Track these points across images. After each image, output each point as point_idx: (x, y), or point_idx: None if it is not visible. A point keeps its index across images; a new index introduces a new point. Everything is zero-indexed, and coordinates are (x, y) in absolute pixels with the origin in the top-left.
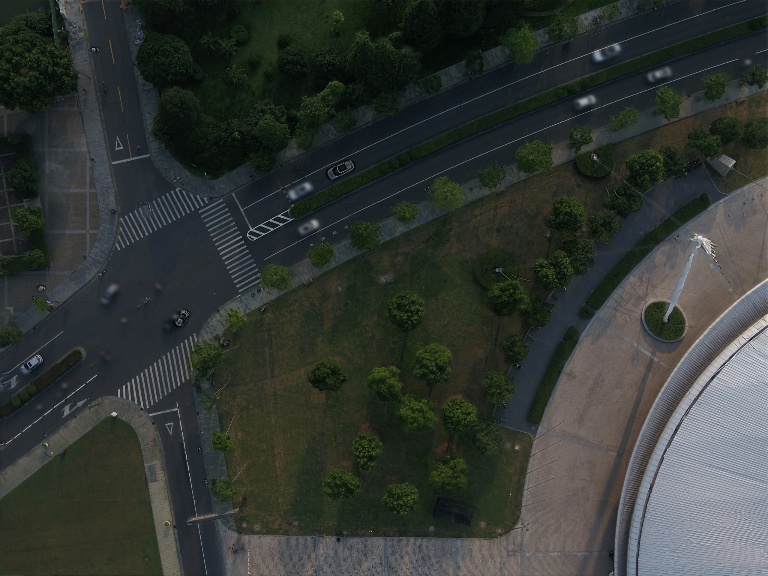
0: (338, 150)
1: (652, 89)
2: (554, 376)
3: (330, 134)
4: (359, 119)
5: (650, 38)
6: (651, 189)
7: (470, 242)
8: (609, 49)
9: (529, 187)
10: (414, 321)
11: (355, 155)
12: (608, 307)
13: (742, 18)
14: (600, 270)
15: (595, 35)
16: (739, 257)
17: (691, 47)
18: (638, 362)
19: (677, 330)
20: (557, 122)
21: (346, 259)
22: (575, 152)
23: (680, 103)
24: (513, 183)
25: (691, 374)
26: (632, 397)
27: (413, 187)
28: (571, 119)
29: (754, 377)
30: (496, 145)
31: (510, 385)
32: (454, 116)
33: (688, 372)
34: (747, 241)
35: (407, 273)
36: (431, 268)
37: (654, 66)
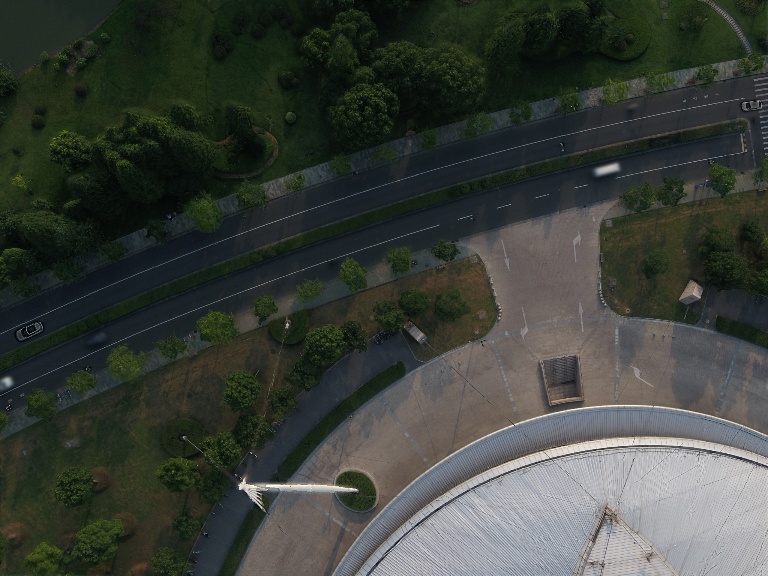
0: (28, 311)
1: (351, 254)
2: (242, 545)
3: (20, 294)
4: (50, 280)
5: (350, 202)
6: (347, 356)
7: (160, 407)
8: (308, 213)
9: (223, 352)
10: (73, 501)
11: (45, 316)
12: (301, 475)
13: (444, 184)
14: (293, 437)
15: (294, 198)
16: (434, 426)
17: (390, 213)
18: (329, 532)
19: (367, 501)
20: (253, 286)
21: (33, 422)
22: (259, 323)
23: None
24: (206, 347)
25: (366, 554)
26: (322, 567)
27: (104, 350)
28: (268, 283)
29: (413, 567)
30: (190, 308)
31: (180, 563)
32: (148, 278)
33: (363, 552)
34: (443, 410)
35: (94, 438)
36: (119, 433)
37: (354, 231)
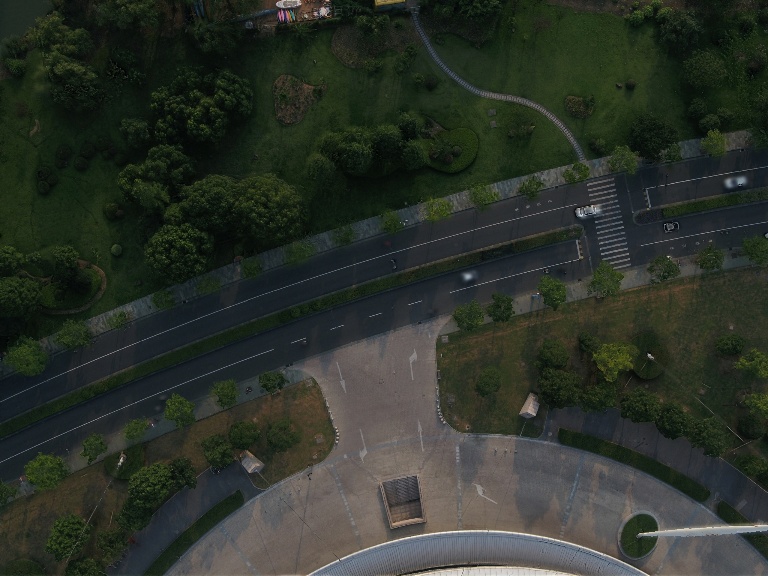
0: None
1: (185, 384)
2: None
3: None
4: None
5: (181, 332)
6: (185, 487)
7: None
8: (139, 344)
9: (60, 489)
10: None
11: None
12: None
13: (275, 308)
14: (135, 571)
15: (125, 331)
16: (276, 554)
17: (220, 342)
18: None
19: None
20: (88, 421)
21: None
22: (88, 463)
23: (191, 412)
24: None
25: None
26: None
27: None
28: (102, 417)
29: None
30: (25, 447)
31: None
32: None
33: None
34: (284, 538)
35: None
36: None
37: (186, 360)
